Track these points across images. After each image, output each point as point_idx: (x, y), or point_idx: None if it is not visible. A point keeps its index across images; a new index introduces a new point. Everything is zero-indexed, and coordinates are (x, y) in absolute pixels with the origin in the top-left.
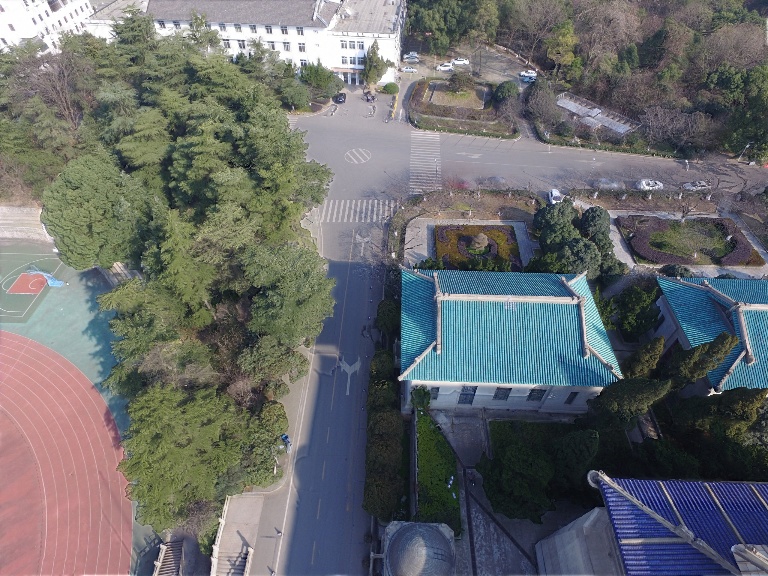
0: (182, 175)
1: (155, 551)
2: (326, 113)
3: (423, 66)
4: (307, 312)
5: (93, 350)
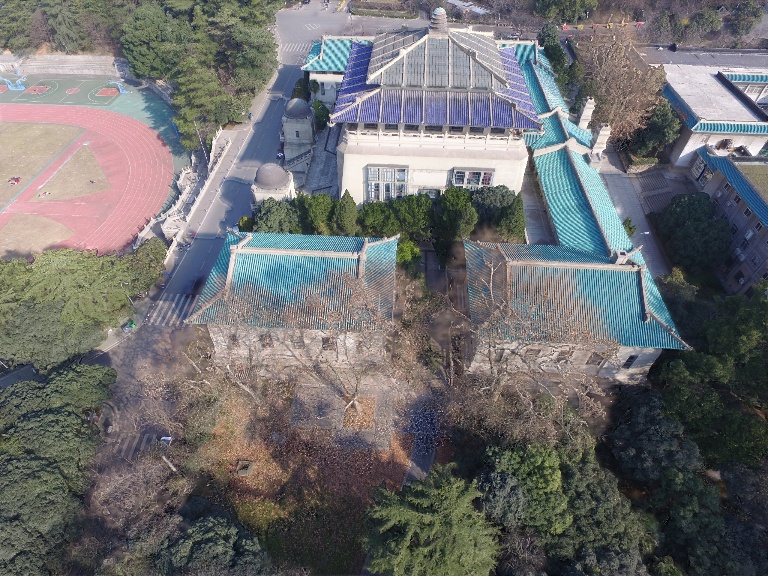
0: None
1: None
2: (295, 8)
3: None
4: (263, 56)
5: (148, 116)
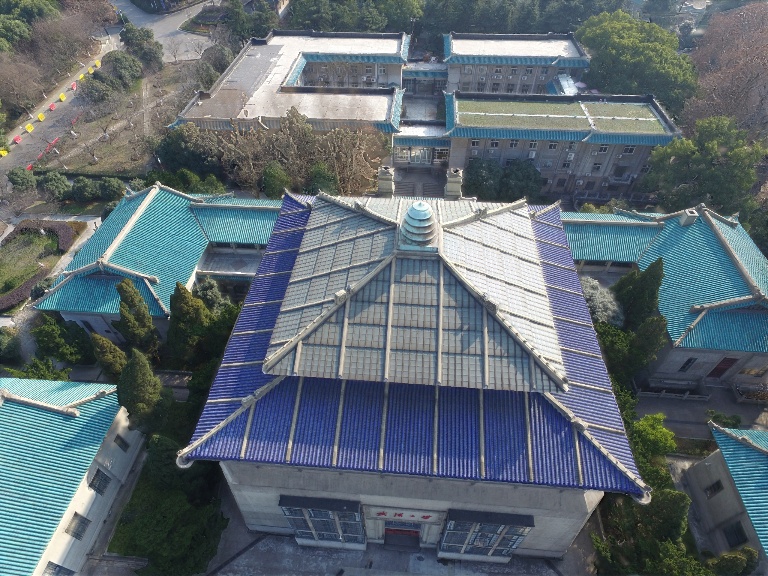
0: None
1: None
2: None
3: None
4: None
5: None
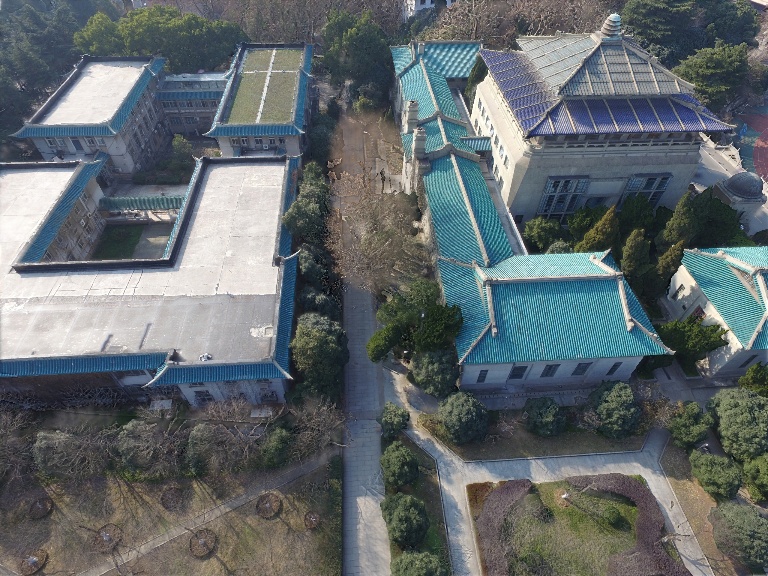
0: None
1: None
2: None
3: None
4: None
5: None
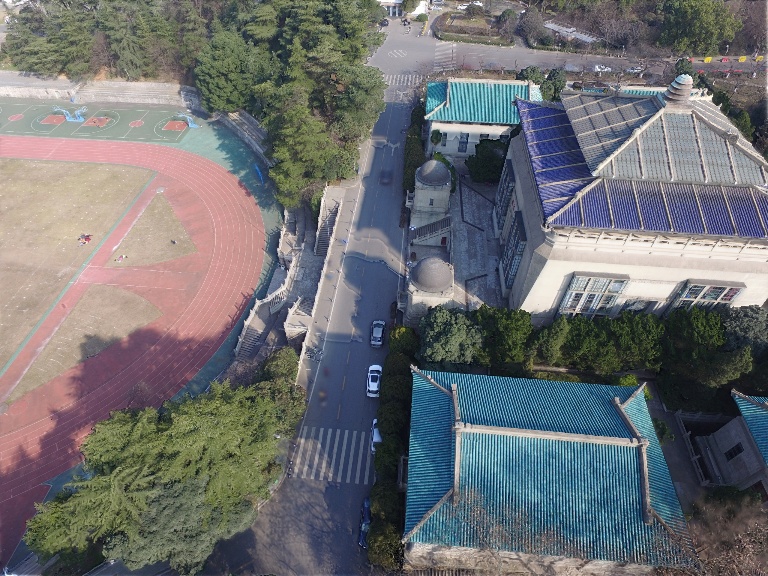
0: (287, 43)
1: (278, 234)
2: None
3: (447, 7)
4: (371, 99)
5: (225, 156)
